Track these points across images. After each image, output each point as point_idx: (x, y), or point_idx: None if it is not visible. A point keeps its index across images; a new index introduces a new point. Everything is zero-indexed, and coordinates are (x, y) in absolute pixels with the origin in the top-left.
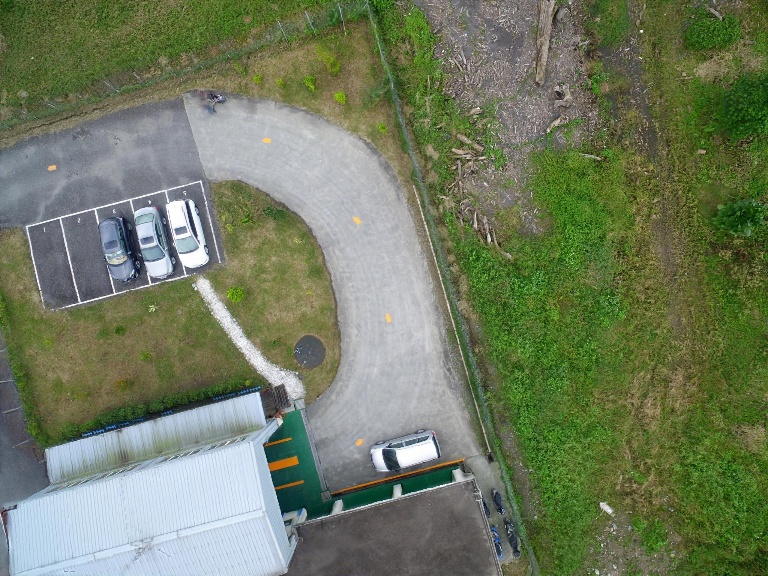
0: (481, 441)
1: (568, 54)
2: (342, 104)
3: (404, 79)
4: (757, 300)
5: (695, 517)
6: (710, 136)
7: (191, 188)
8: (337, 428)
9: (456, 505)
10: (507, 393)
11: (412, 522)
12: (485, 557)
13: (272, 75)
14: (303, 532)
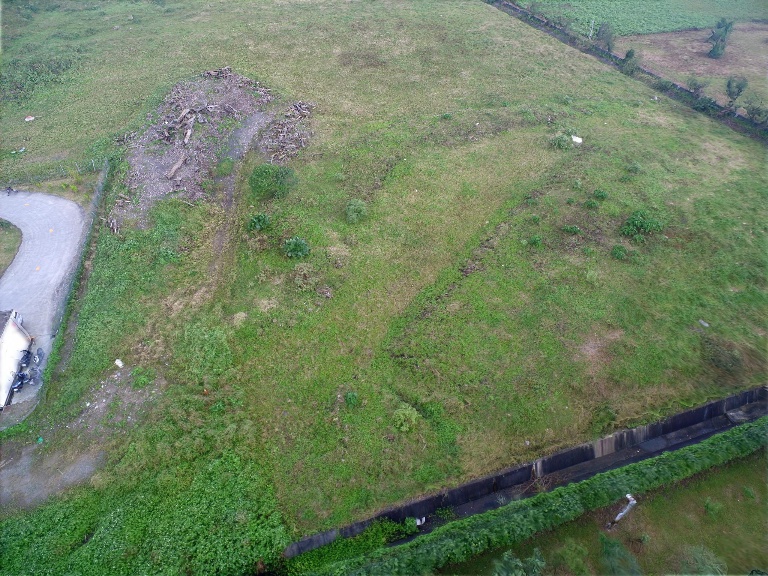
0: (54, 328)
1: (189, 171)
2: (75, 192)
3: (112, 184)
4: (262, 257)
5: None
6: (258, 202)
7: None
8: None
9: None
10: None
11: None
12: None
13: None
14: None
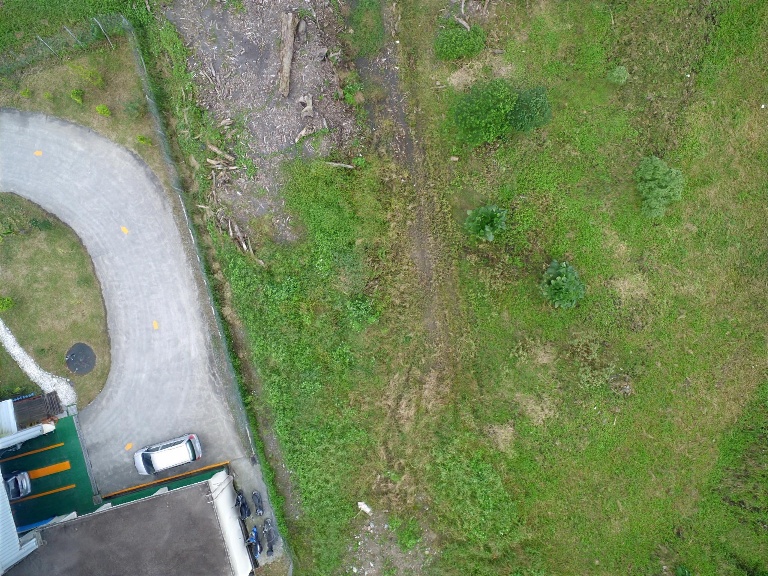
0: (245, 444)
1: (314, 65)
2: (108, 117)
3: (167, 91)
4: (506, 303)
5: (447, 515)
6: (463, 143)
7: None
8: (108, 433)
9: (193, 507)
10: (266, 397)
11: (151, 524)
12: (221, 557)
13: (43, 89)
14: (47, 535)
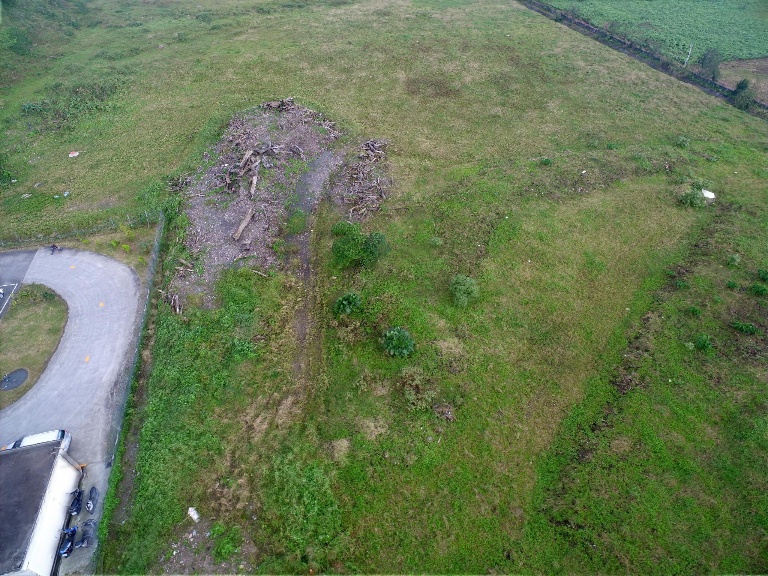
0: (109, 450)
1: (258, 230)
2: (127, 252)
3: (169, 243)
4: (356, 353)
5: (272, 523)
6: (341, 271)
7: (8, 287)
8: None
9: (36, 464)
10: None
11: None
12: (32, 513)
13: None
14: None
